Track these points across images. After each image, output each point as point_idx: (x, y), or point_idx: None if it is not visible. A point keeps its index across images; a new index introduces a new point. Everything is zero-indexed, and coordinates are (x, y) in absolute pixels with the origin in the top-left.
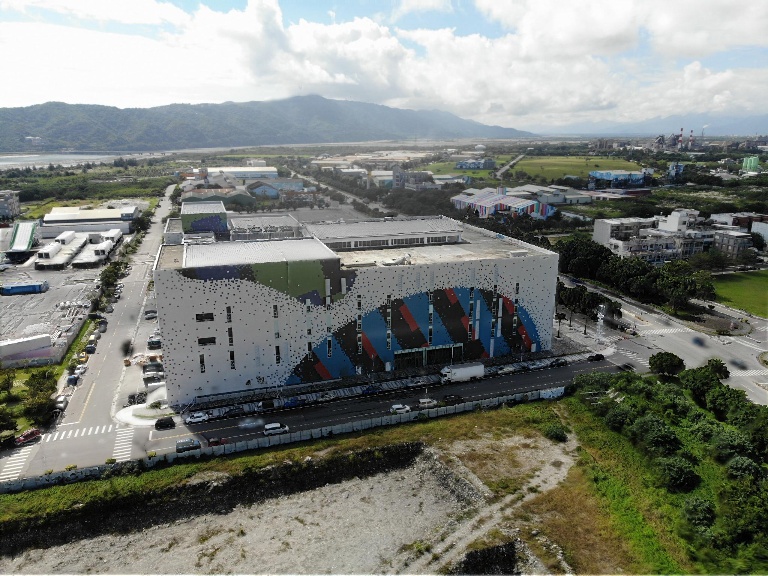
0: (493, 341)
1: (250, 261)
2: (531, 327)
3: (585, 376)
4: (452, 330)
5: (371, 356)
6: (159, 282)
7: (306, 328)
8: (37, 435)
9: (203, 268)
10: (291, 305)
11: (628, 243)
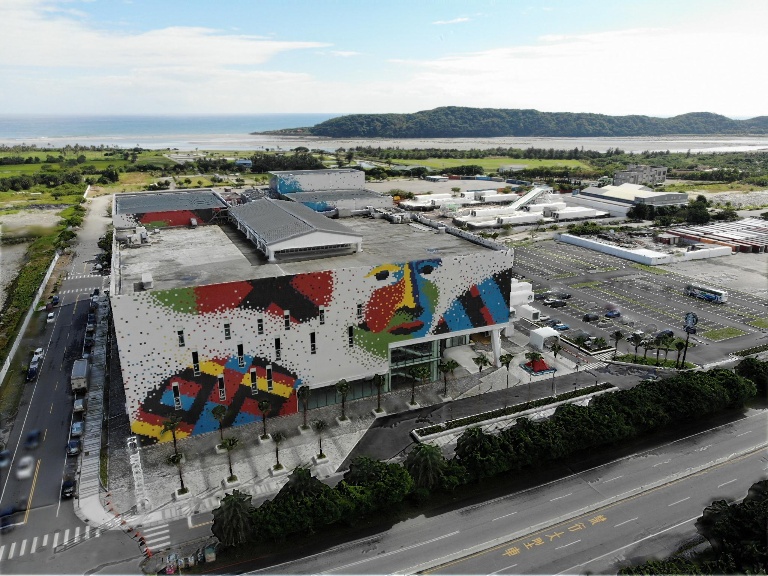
0: None
1: None
2: None
3: None
4: None
5: None
6: None
7: None
8: (109, 273)
9: None
10: None
11: None
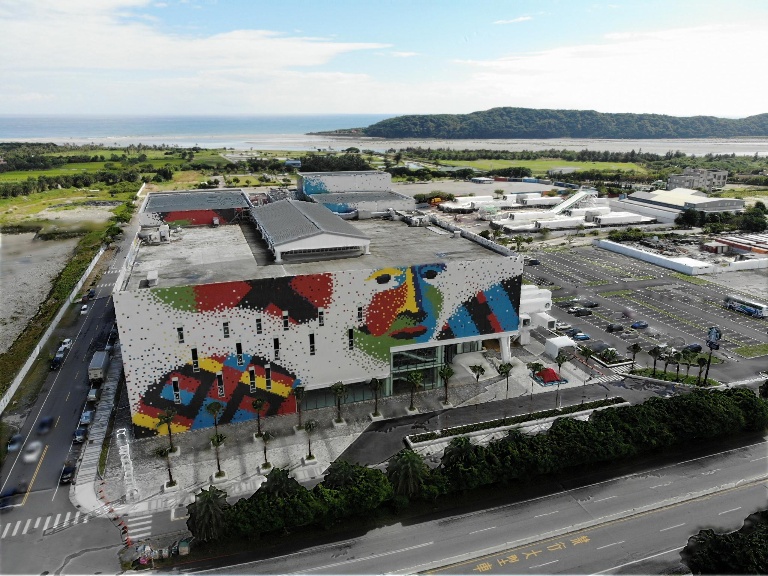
0: None
1: None
2: None
3: None
4: None
5: None
6: None
7: None
8: None
9: None
10: None
11: None
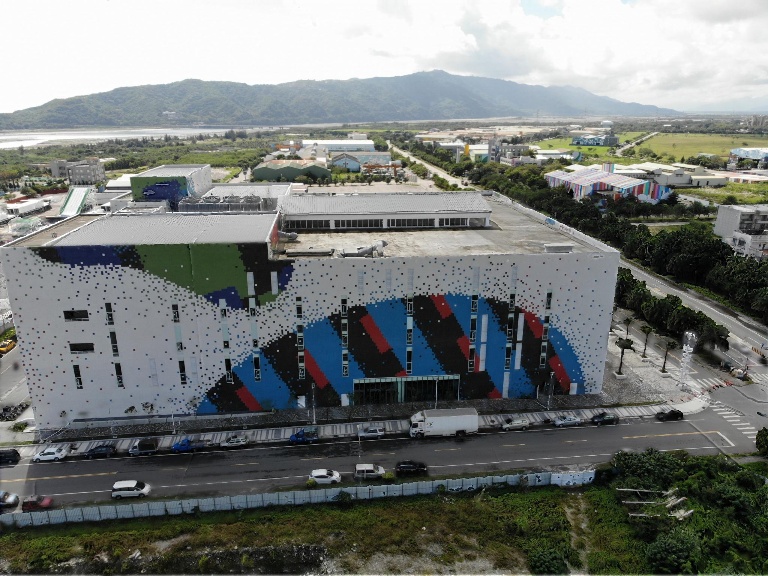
0: (508, 375)
1: (147, 241)
2: (570, 359)
3: (631, 458)
4: (443, 355)
5: (319, 383)
6: (8, 264)
7: (222, 339)
8: None
9: (67, 248)
10: (198, 306)
11: (760, 238)
